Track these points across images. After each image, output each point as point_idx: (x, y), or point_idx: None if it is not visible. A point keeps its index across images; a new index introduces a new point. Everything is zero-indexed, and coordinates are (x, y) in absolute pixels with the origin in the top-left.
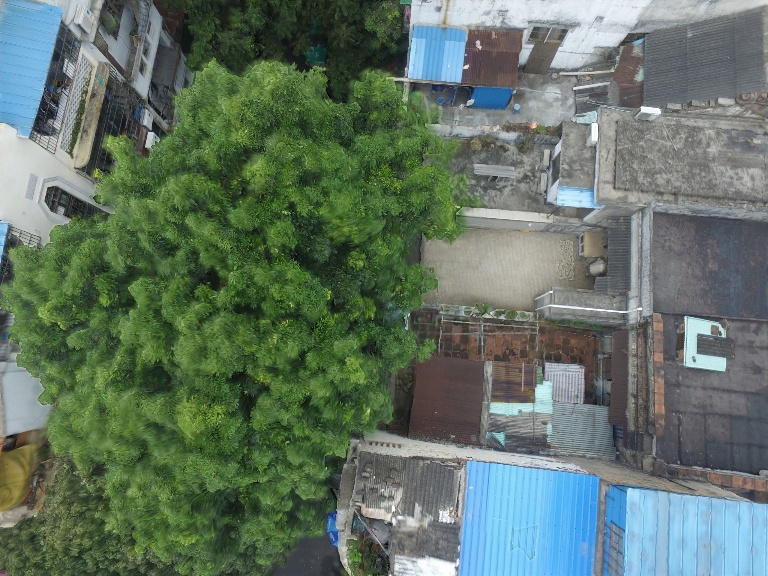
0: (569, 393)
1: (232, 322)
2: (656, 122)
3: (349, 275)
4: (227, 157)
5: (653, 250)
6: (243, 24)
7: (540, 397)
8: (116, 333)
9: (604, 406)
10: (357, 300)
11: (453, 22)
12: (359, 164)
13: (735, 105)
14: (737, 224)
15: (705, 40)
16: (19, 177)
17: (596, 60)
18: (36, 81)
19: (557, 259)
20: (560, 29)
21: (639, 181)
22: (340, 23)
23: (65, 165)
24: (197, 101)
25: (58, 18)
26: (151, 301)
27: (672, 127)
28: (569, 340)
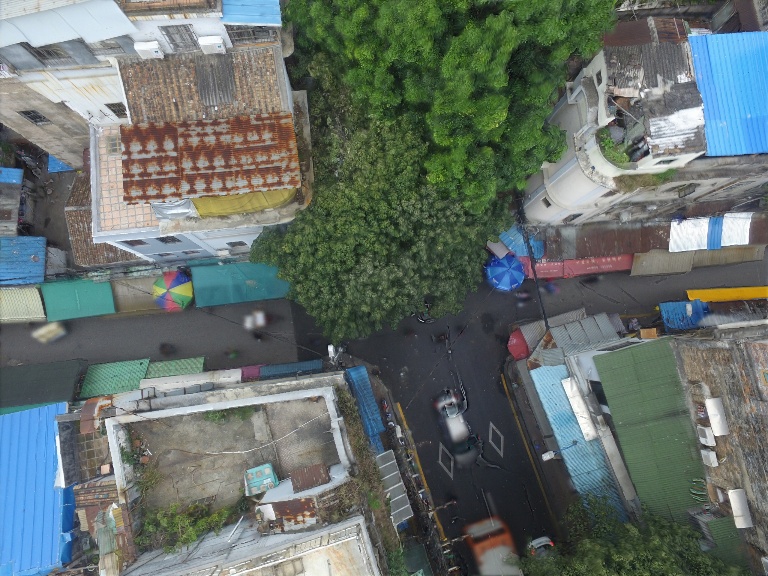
0: None
1: None
2: None
3: None
4: None
5: None
6: None
7: None
8: None
9: None
10: None
11: None
12: None
13: None
14: None
15: None
16: None
17: None
18: None
19: None
20: None
21: None
22: None
23: None
24: None
25: None
26: None
27: None
28: None
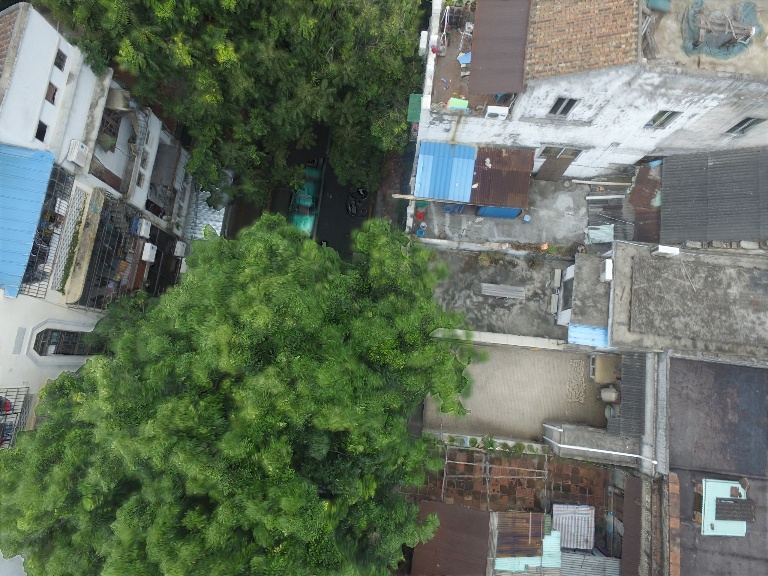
0: (578, 538)
1: (220, 573)
2: (674, 258)
3: (348, 464)
4: (219, 367)
5: (669, 398)
6: (244, 135)
7: (548, 550)
8: (99, 550)
9: (615, 558)
10: (356, 487)
11: (462, 140)
12: (360, 345)
13: (758, 249)
14: (759, 372)
15: (727, 171)
16: (6, 336)
17: (610, 172)
18: (25, 234)
19: (567, 380)
20: (574, 149)
21: (655, 324)
22: (345, 123)
23: (56, 304)
24: (189, 303)
25: (50, 165)
26: (135, 535)
27: (691, 265)
28: (578, 469)
